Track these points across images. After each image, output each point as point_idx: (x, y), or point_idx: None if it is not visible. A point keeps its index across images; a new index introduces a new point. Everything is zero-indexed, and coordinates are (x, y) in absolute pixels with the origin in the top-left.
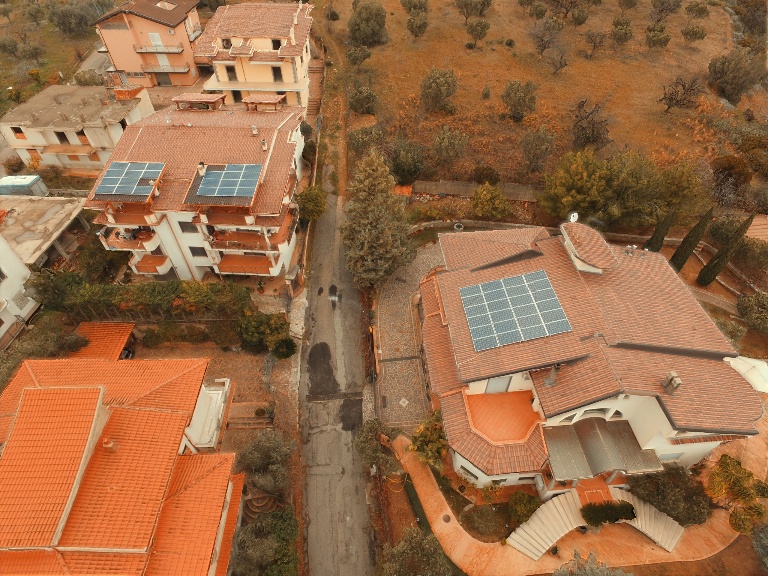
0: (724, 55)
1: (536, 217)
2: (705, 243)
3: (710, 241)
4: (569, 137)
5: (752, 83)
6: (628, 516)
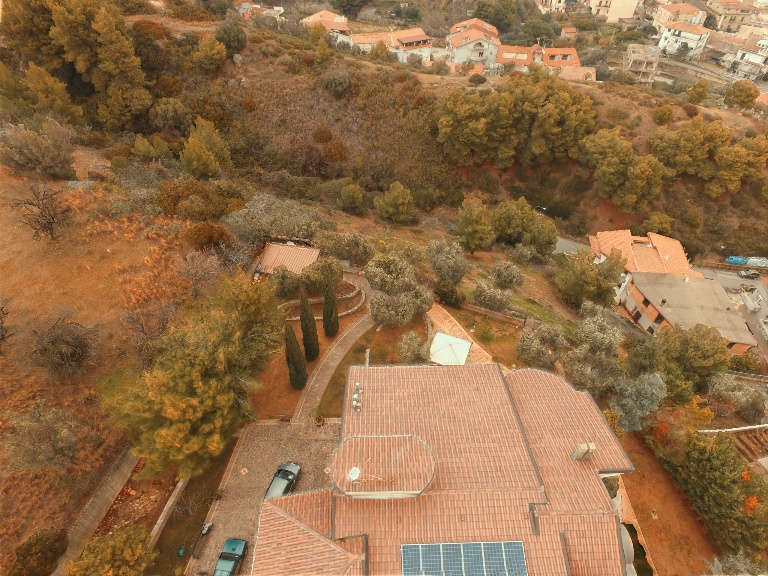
0: (3, 144)
1: (160, 482)
2: (280, 306)
3: (279, 300)
4: (21, 371)
5: (71, 152)
6: (635, 532)
